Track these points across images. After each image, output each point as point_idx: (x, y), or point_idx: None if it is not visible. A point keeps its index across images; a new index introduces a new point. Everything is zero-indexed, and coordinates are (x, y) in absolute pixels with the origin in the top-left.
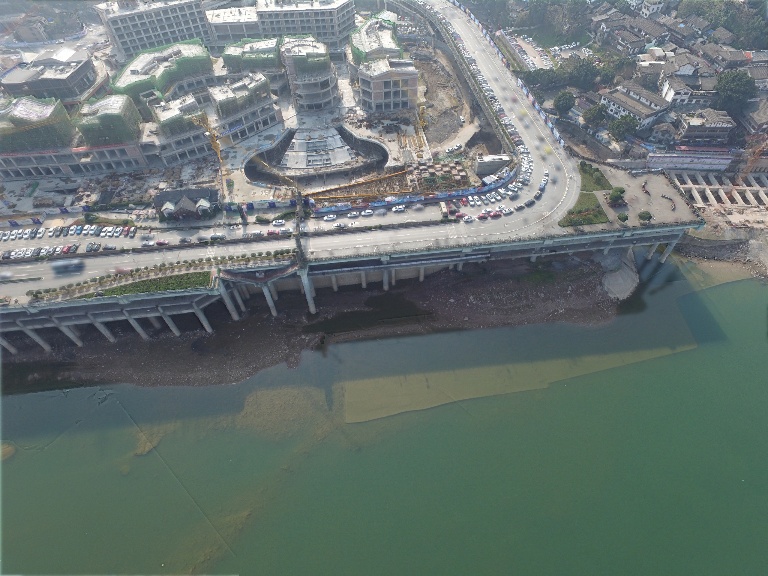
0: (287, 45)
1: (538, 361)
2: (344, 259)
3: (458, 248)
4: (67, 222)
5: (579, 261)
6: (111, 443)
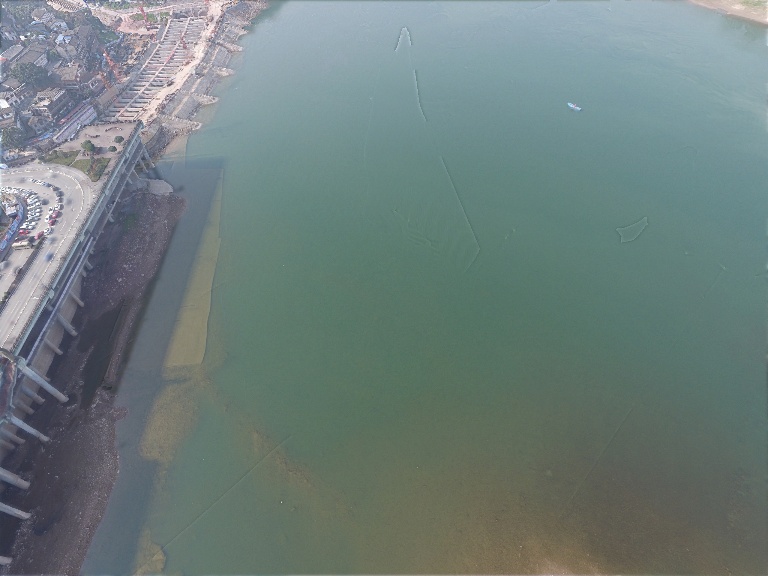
0: None
1: (200, 240)
2: (30, 324)
3: (77, 241)
4: None
5: (129, 198)
6: None
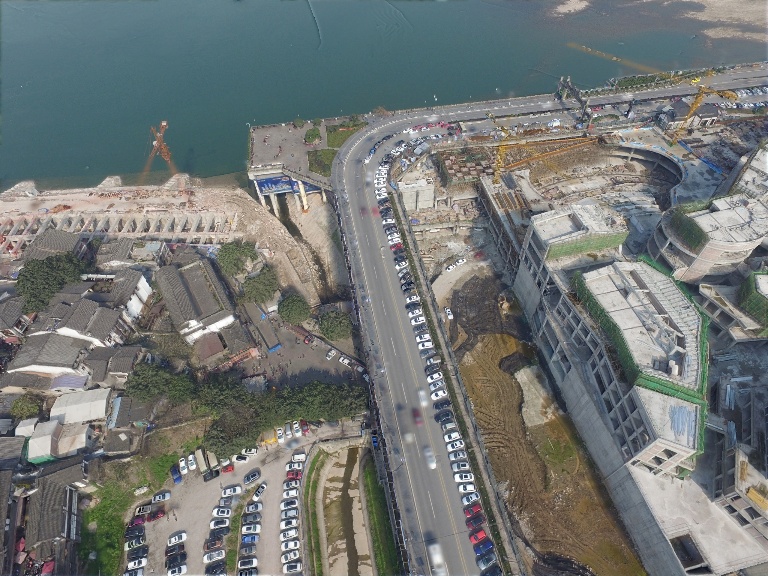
0: (767, 219)
1: None
2: None
3: None
4: None
5: None
6: None
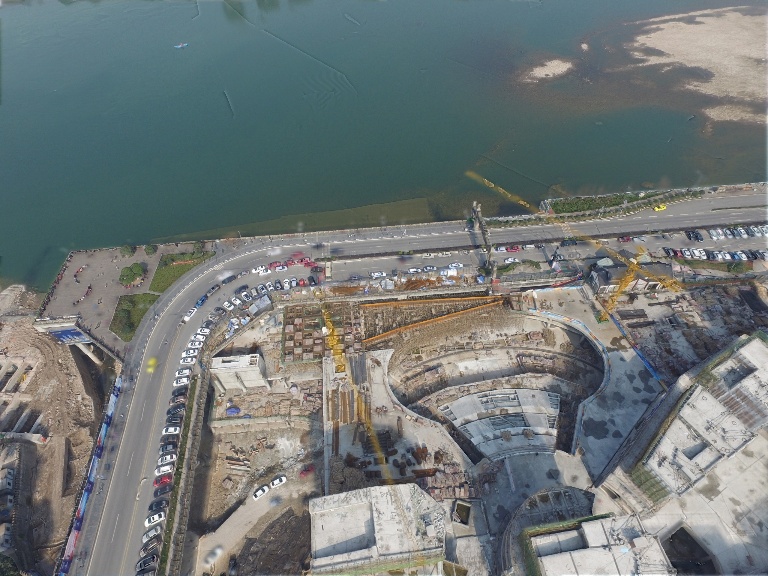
0: None
1: (281, 230)
2: None
3: None
4: (761, 266)
5: None
6: (580, 189)
